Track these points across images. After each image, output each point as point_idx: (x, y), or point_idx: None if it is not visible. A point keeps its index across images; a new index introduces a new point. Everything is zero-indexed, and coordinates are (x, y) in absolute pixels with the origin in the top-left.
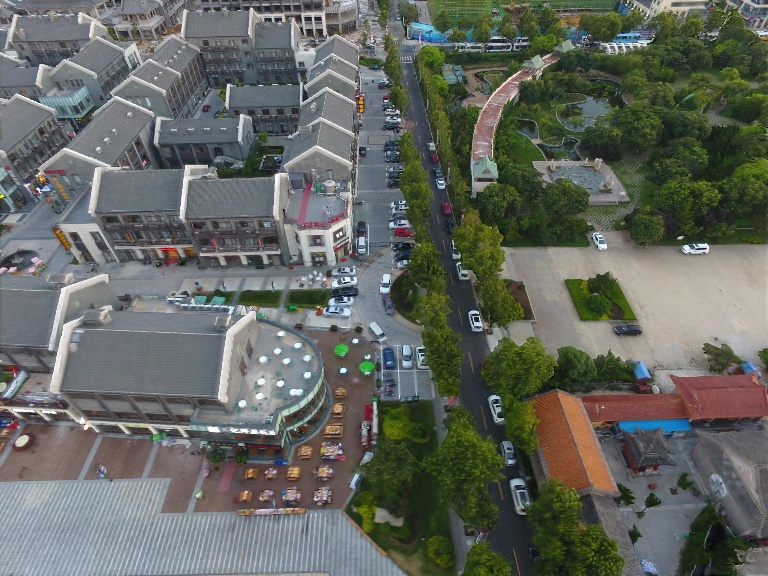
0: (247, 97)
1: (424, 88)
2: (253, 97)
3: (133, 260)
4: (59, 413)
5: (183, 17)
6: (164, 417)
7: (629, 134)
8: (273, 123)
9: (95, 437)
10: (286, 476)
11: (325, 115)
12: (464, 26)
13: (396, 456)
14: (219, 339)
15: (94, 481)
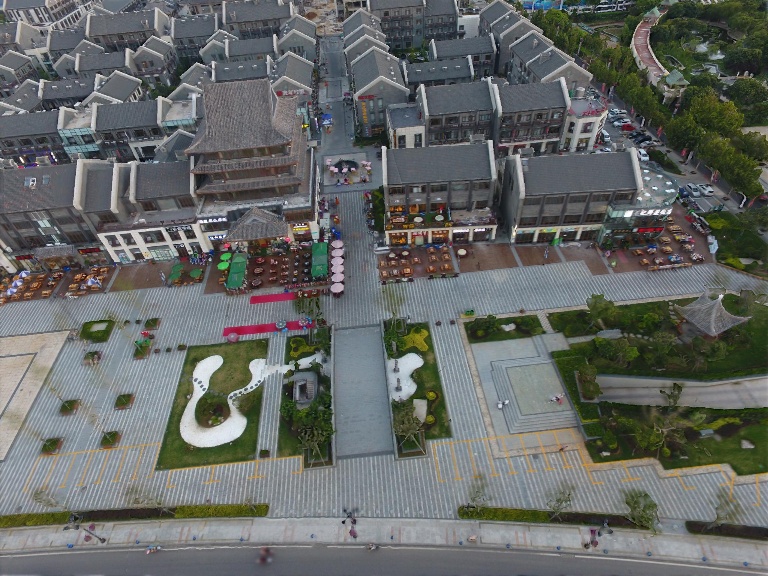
0: (449, 48)
1: None
2: (454, 48)
3: None
4: (486, 230)
5: None
6: (574, 219)
7: (763, 54)
8: None
9: (509, 247)
10: (663, 251)
11: None
12: None
13: (762, 213)
14: (624, 155)
15: (532, 266)
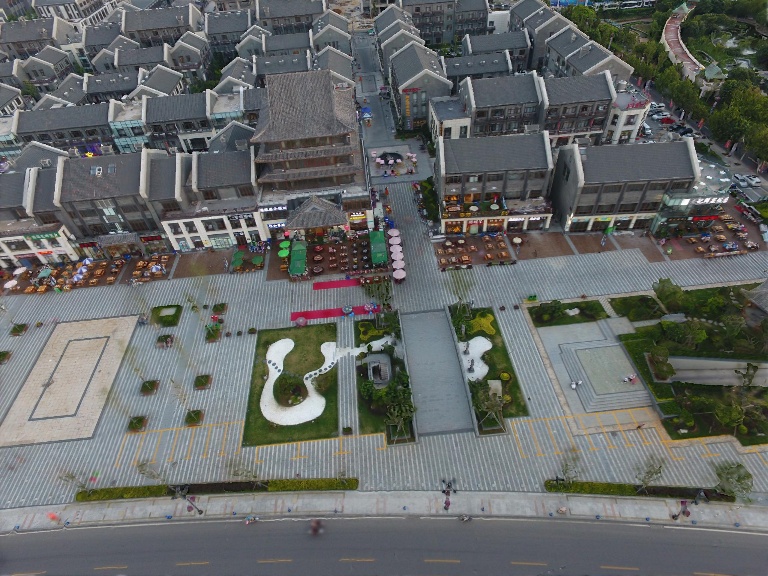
0: (484, 43)
1: None
2: (489, 43)
3: None
4: (541, 219)
5: None
6: (629, 208)
7: None
8: None
9: (563, 236)
10: (717, 239)
11: None
12: None
13: None
14: (681, 144)
15: (588, 254)
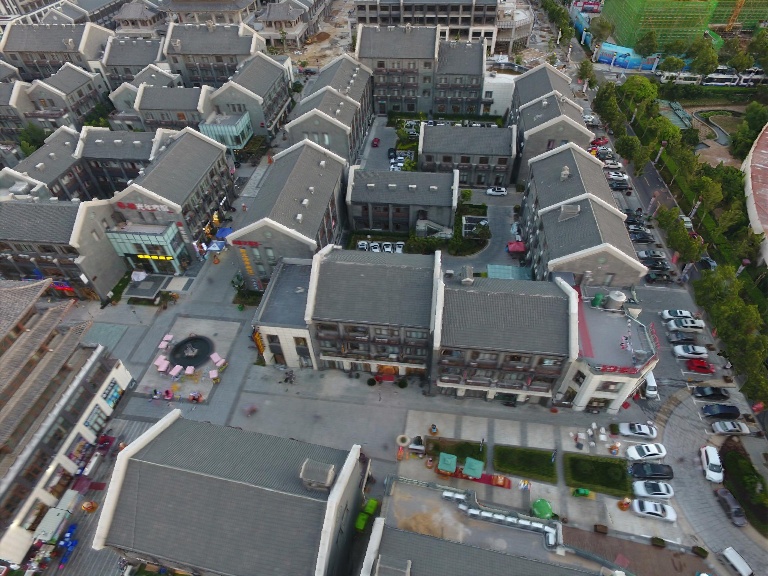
0: (444, 140)
1: (642, 132)
2: (452, 140)
3: (334, 368)
4: None
5: (358, 33)
6: None
7: None
8: (470, 173)
9: None
10: None
11: (586, 186)
12: (675, 51)
13: None
14: None
15: None
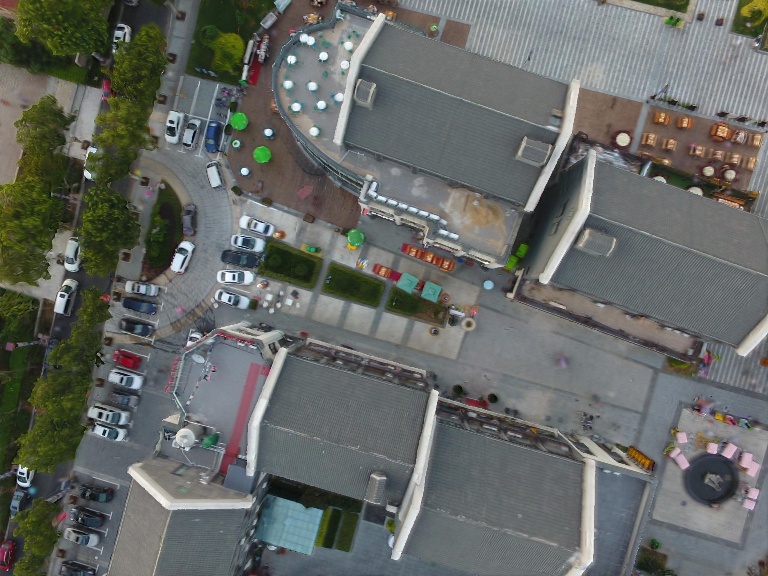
0: None
1: None
2: None
3: None
4: None
5: None
6: None
7: None
8: None
9: None
10: None
11: None
12: None
13: None
14: (373, 65)
15: None
